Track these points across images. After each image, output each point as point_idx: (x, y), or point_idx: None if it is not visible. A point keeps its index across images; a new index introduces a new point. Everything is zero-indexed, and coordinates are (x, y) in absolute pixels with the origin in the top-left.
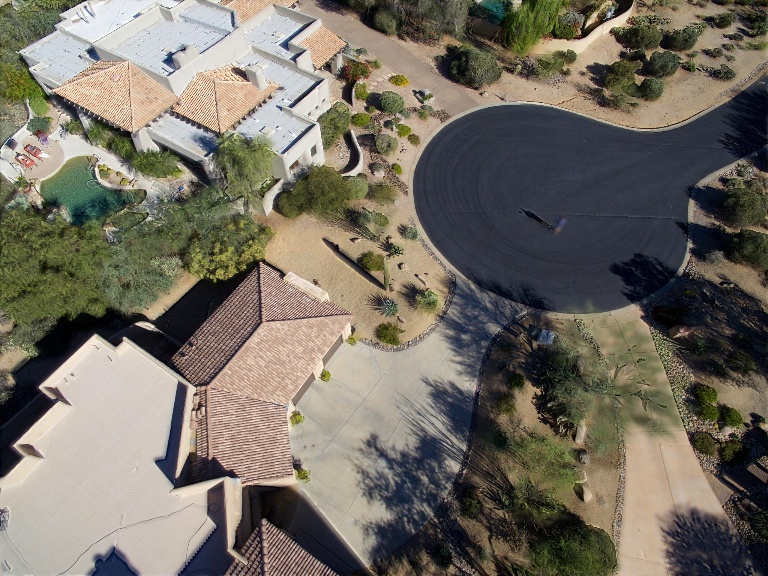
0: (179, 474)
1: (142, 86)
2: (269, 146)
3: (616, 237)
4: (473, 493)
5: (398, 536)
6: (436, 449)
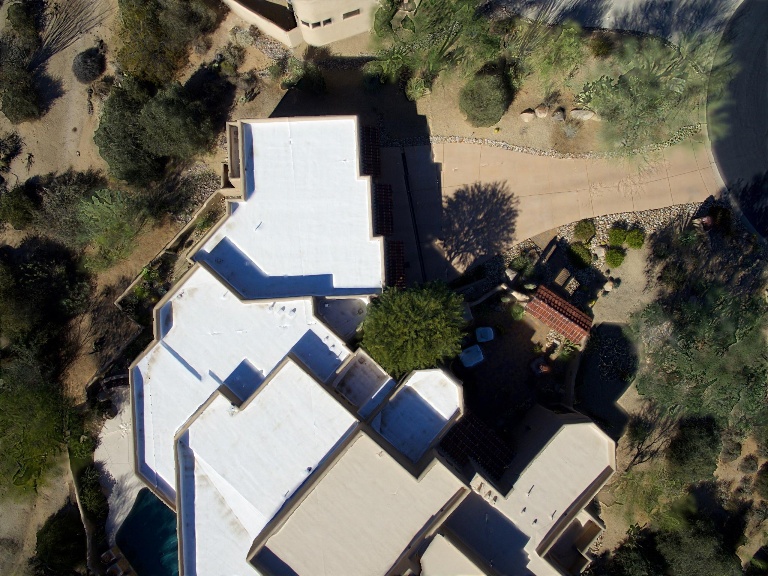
0: None
1: None
2: None
3: None
4: (515, 23)
5: None
6: None
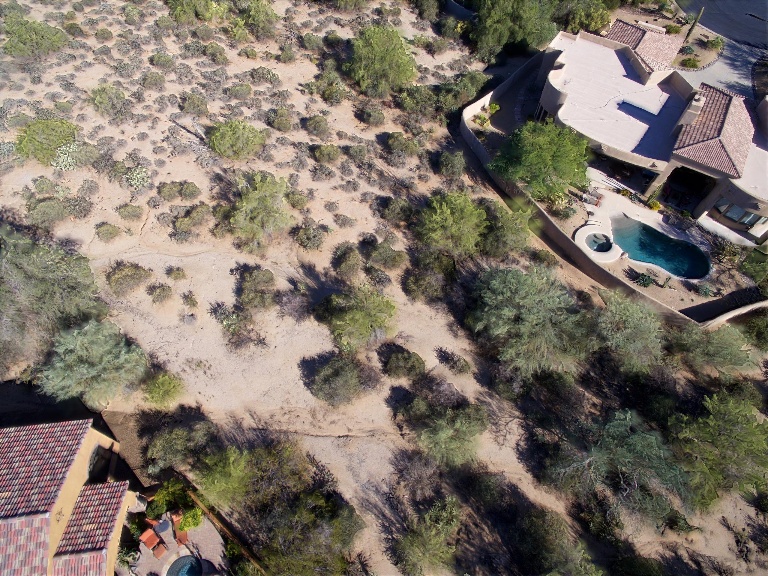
0: None
1: None
2: None
3: None
4: None
5: None
6: None
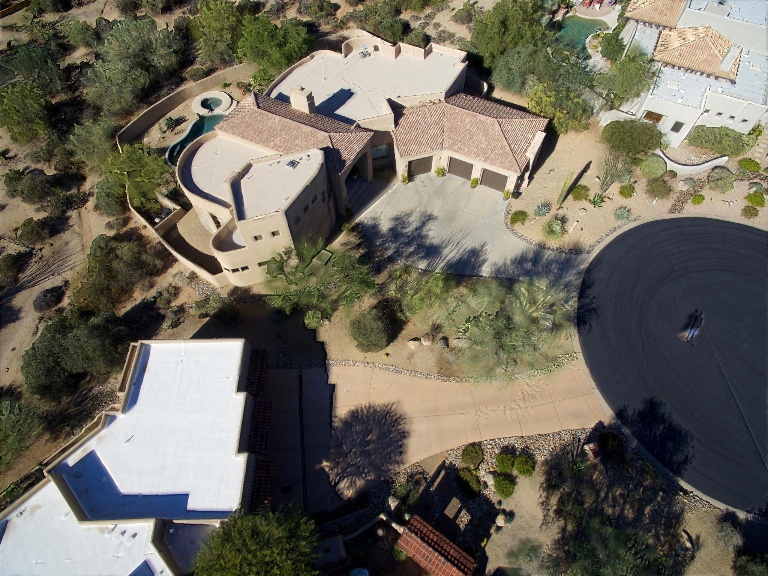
0: (393, 99)
1: (673, 3)
2: (658, 89)
3: (709, 412)
4: (406, 271)
5: (375, 235)
6: (434, 254)
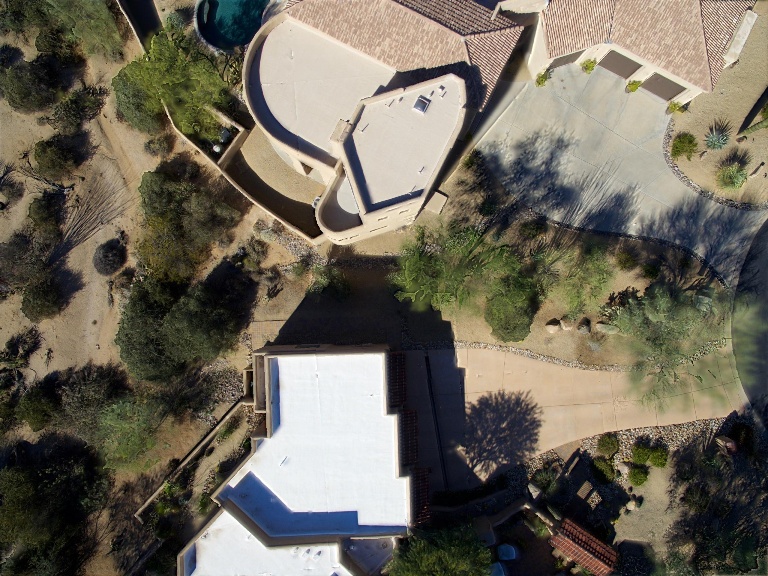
0: None
1: None
2: None
3: None
4: (542, 230)
5: (500, 170)
6: (573, 200)
